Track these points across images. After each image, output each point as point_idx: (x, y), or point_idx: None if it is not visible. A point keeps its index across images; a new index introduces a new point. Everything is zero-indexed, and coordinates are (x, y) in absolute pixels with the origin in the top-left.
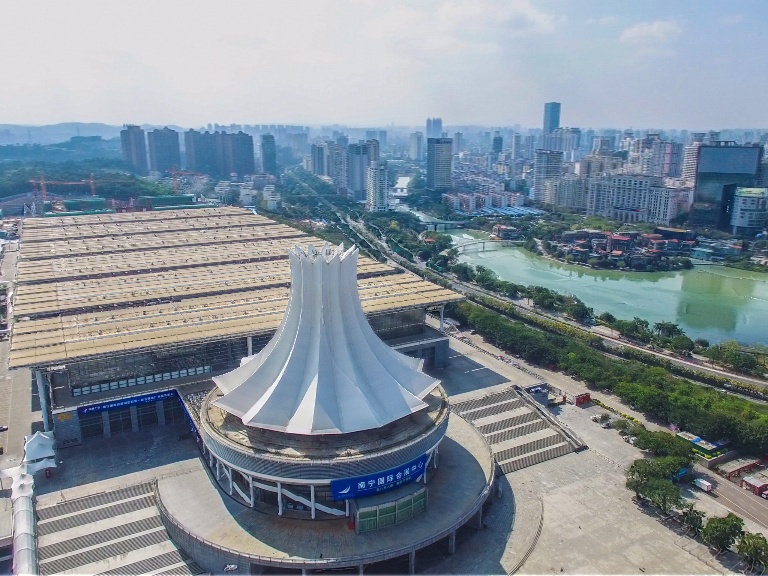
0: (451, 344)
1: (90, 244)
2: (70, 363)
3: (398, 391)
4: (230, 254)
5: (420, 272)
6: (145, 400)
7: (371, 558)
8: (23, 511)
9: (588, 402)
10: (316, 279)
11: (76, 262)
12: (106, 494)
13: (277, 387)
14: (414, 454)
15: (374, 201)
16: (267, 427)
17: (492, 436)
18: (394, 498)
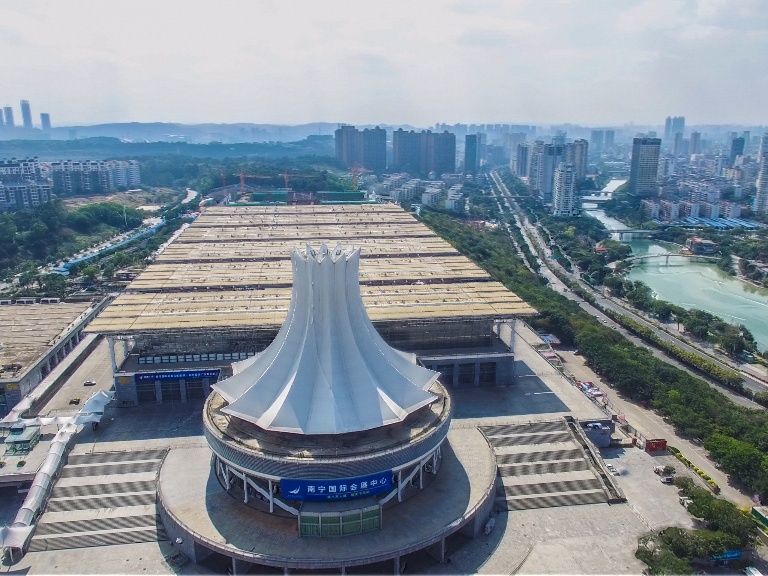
0: (531, 362)
1: (238, 232)
2: (136, 334)
3: (377, 401)
4: (344, 249)
5: (568, 282)
6: (193, 376)
7: (296, 563)
8: (53, 454)
9: (663, 449)
10: (308, 278)
11: (213, 247)
12: (125, 453)
13: (261, 379)
14: (374, 468)
15: (558, 204)
16: (240, 416)
17: (515, 467)
18: (341, 509)
